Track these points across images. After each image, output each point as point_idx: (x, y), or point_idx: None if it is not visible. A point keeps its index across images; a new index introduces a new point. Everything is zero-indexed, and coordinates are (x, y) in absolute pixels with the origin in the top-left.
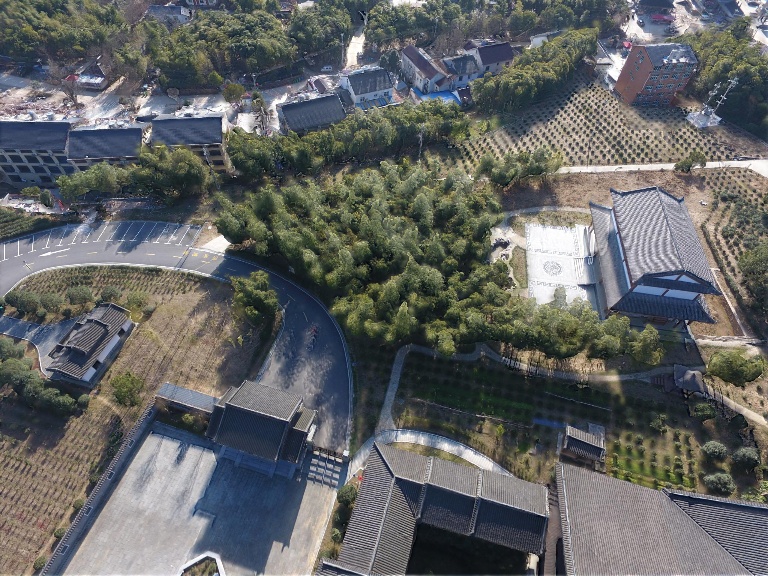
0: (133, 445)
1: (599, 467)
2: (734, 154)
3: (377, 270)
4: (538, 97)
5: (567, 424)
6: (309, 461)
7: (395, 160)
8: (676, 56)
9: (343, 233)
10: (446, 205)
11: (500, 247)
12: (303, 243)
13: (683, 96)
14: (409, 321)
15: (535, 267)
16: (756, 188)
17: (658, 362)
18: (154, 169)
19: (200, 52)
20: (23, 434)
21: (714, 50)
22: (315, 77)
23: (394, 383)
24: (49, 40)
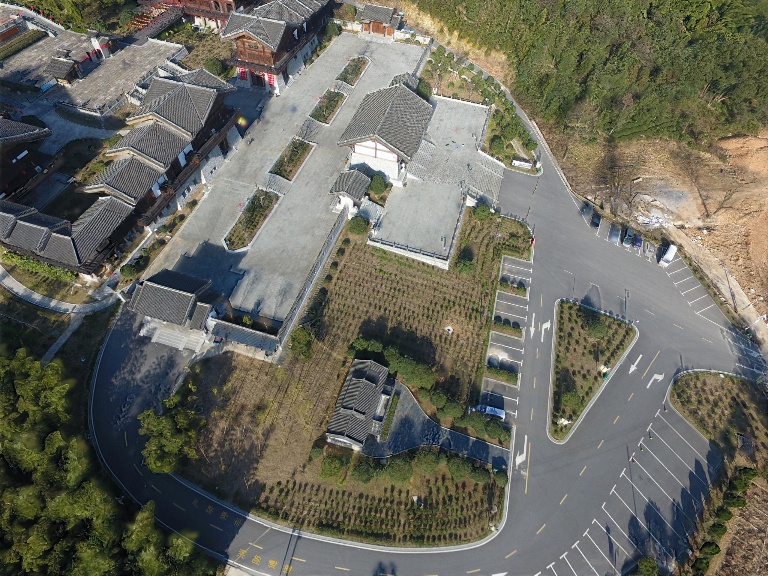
0: None
1: None
2: None
3: None
4: None
5: None
6: None
7: None
8: None
9: (4, 536)
10: None
11: None
12: None
13: None
14: None
15: None
16: None
17: None
18: None
19: None
20: None
21: None
22: None
23: (53, 350)
24: None
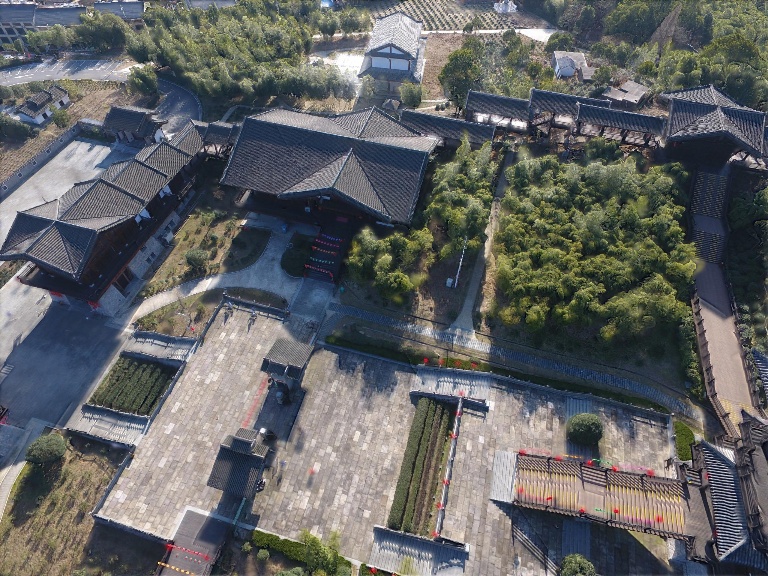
0: (63, 143)
1: None
2: None
3: None
4: None
5: None
6: None
7: None
8: None
9: None
10: (272, 30)
11: None
12: None
13: None
14: (229, 79)
15: None
16: None
17: (372, 95)
18: (90, 24)
19: None
20: None
21: None
22: None
23: (224, 120)
24: None
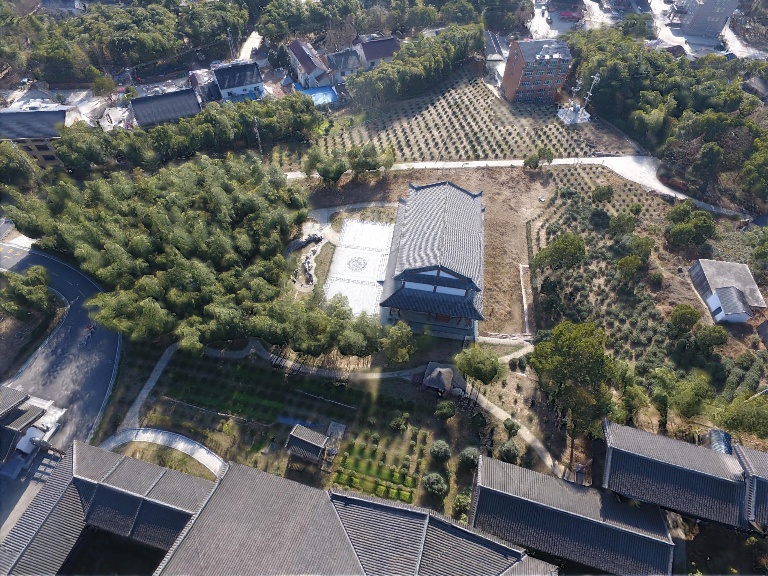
0: None
1: (325, 467)
2: (593, 151)
3: (157, 265)
4: (409, 93)
5: (309, 423)
6: (40, 460)
7: None
8: (549, 52)
9: (135, 228)
10: (243, 199)
11: (313, 243)
12: (83, 237)
13: (566, 93)
14: (162, 317)
15: (339, 263)
16: (601, 185)
17: (407, 359)
18: None
19: (76, 45)
20: None
21: (596, 46)
22: (194, 72)
23: (152, 381)
24: None
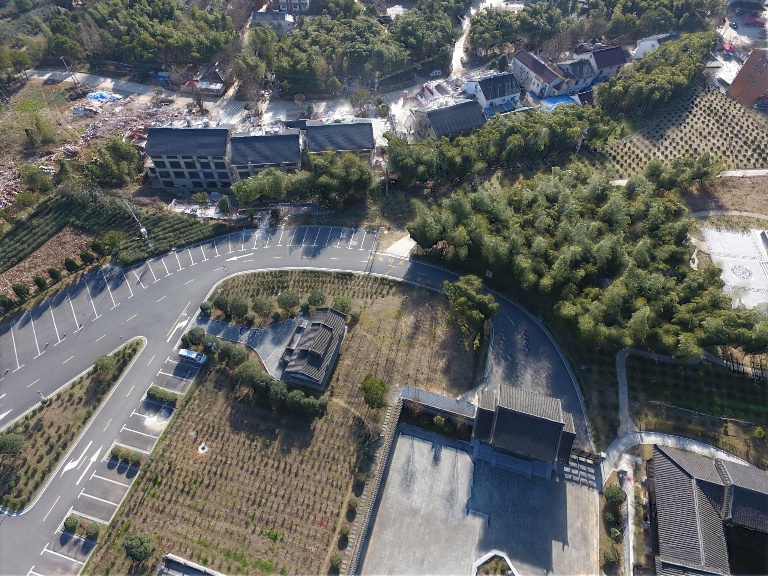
0: None
1: None
2: None
3: (586, 275)
4: None
5: None
6: None
7: (544, 165)
8: None
9: None
10: (641, 210)
11: None
12: (512, 248)
13: None
14: None
15: (724, 271)
16: None
17: None
18: (329, 175)
19: (320, 58)
20: (272, 435)
21: None
22: (433, 82)
23: (623, 386)
24: (166, 47)
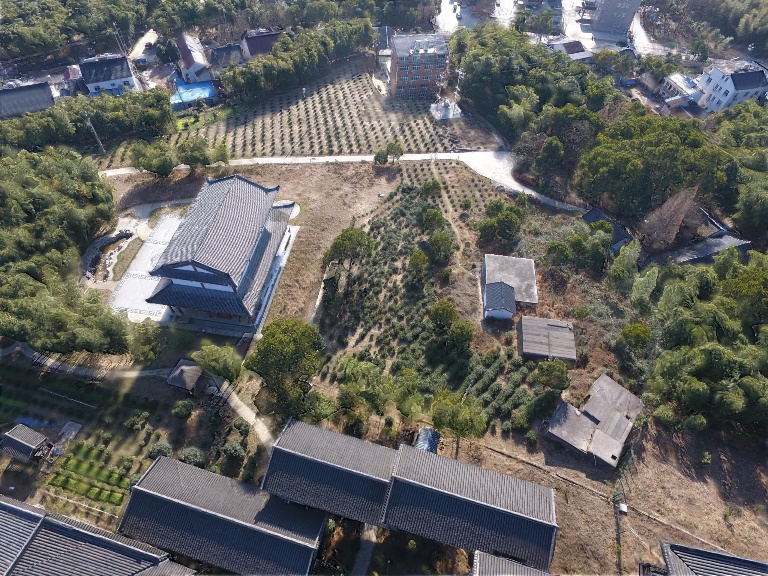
0: None
1: (45, 468)
2: (454, 146)
3: None
4: (281, 87)
5: (46, 422)
6: None
7: (85, 150)
8: (424, 46)
9: None
10: (36, 194)
11: (125, 239)
12: None
13: (451, 88)
14: None
15: (142, 259)
16: (448, 180)
17: (152, 357)
18: None
19: None
20: None
21: None
22: (72, 66)
23: None
24: None
